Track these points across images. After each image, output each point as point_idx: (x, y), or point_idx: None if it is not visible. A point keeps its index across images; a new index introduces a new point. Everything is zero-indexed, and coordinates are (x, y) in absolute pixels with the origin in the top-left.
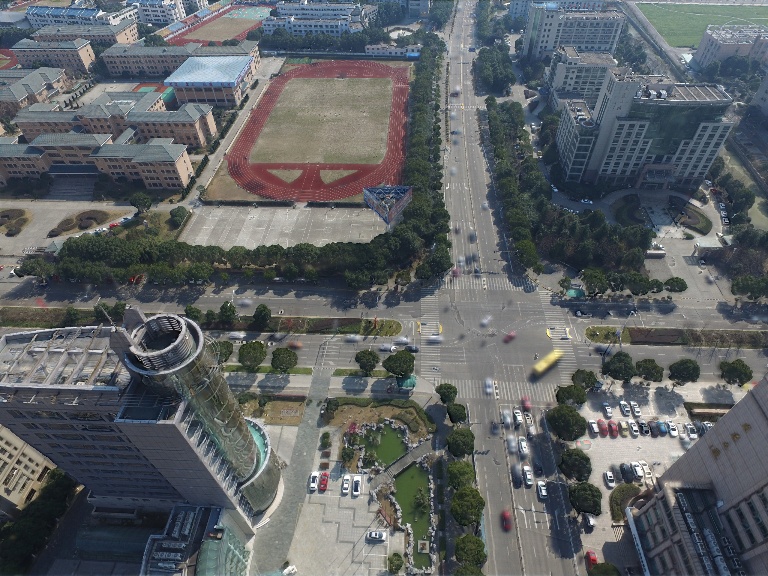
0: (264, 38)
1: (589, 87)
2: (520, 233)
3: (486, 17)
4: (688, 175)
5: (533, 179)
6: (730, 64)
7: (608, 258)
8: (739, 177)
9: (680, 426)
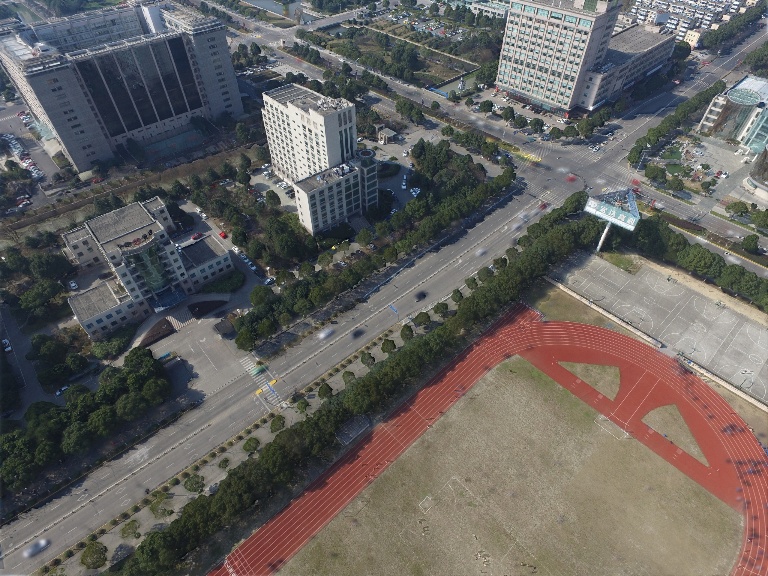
0: None
1: None
2: None
3: None
4: None
5: None
6: None
7: None
8: None
9: (528, 118)
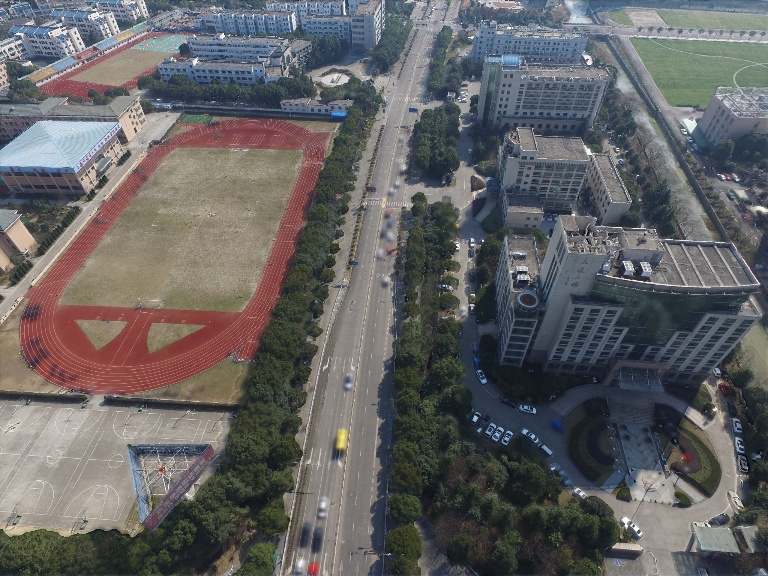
0: (155, 88)
1: (552, 186)
2: (400, 511)
3: (442, 58)
4: (685, 369)
5: (444, 375)
6: (747, 145)
7: (543, 571)
8: (763, 371)
9: None
